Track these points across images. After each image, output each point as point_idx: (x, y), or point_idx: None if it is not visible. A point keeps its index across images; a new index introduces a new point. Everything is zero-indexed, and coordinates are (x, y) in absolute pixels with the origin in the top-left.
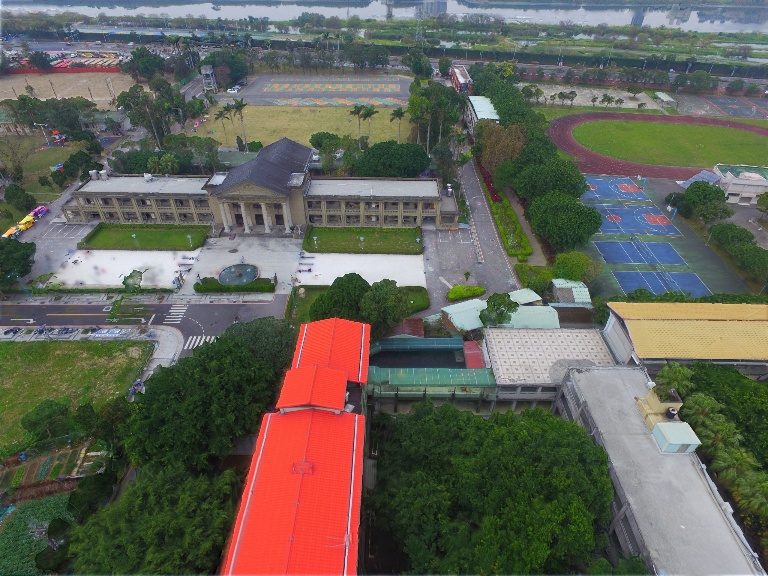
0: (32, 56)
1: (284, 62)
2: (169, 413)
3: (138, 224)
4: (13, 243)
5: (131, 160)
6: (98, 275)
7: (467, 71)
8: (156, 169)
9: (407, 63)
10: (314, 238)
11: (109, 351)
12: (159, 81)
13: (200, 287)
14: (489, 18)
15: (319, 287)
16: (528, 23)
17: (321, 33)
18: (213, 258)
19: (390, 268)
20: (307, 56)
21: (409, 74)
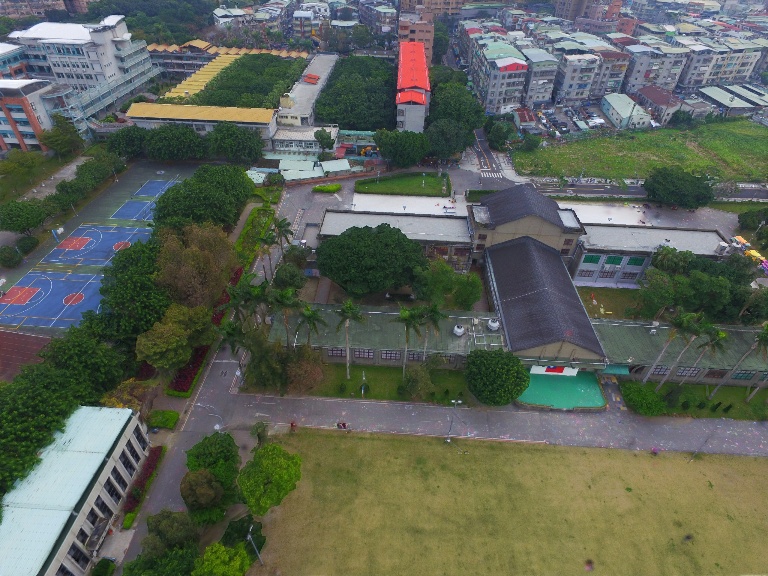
0: None
1: None
2: (466, 103)
3: None
4: (674, 189)
5: None
6: (608, 212)
7: None
8: None
9: None
10: None
11: None
12: None
13: None
14: None
15: None
16: None
17: None
18: None
19: (380, 208)
20: None
21: None
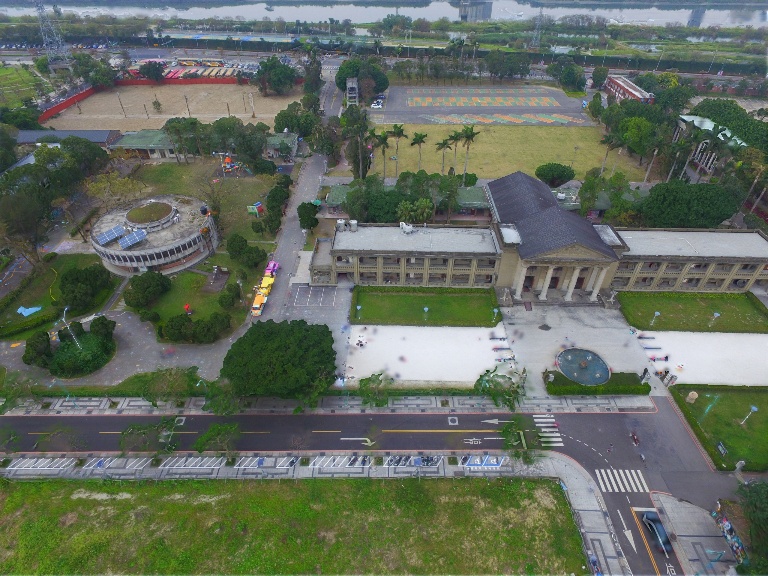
0: (146, 66)
1: (418, 72)
2: None
3: (402, 287)
4: (313, 329)
5: (372, 204)
6: (402, 365)
7: (633, 83)
8: (406, 216)
9: (552, 73)
10: (657, 314)
11: (514, 498)
12: (310, 97)
13: (560, 389)
14: (591, 20)
15: (705, 387)
16: (630, 25)
17: (416, 37)
18: (528, 338)
19: (762, 355)
20: (445, 65)
21: (553, 85)
